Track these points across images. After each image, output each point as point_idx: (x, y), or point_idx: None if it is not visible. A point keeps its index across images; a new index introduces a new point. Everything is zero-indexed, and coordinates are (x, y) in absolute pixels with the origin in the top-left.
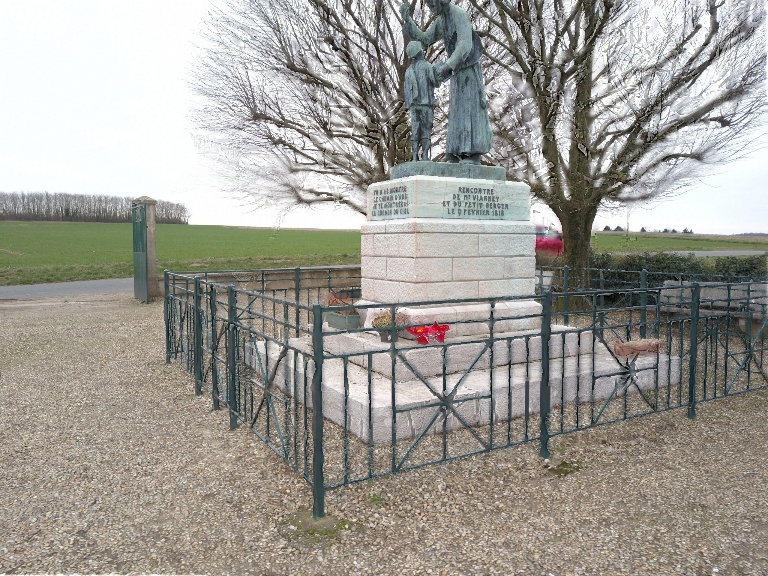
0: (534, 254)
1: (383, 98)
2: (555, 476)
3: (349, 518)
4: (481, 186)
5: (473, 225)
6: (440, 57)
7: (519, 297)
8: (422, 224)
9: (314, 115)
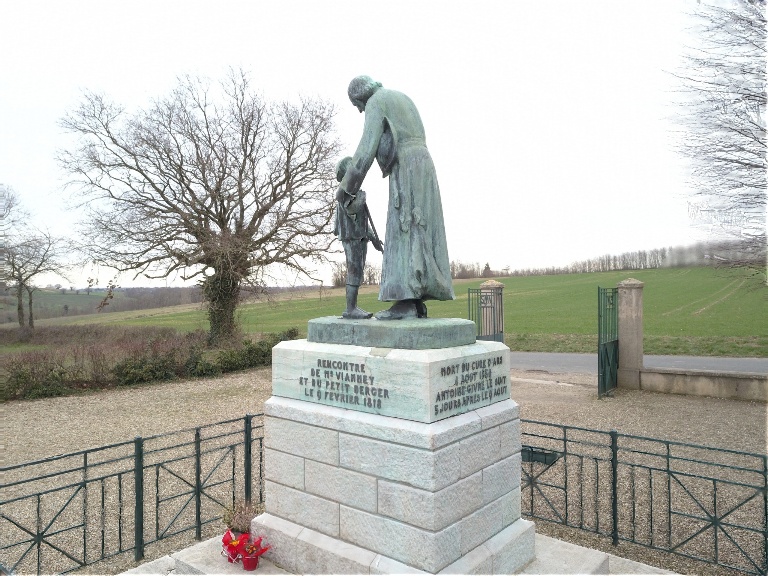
0: (430, 487)
1: None
2: None
3: None
4: (348, 359)
5: (330, 417)
6: None
7: None
8: (271, 406)
9: None
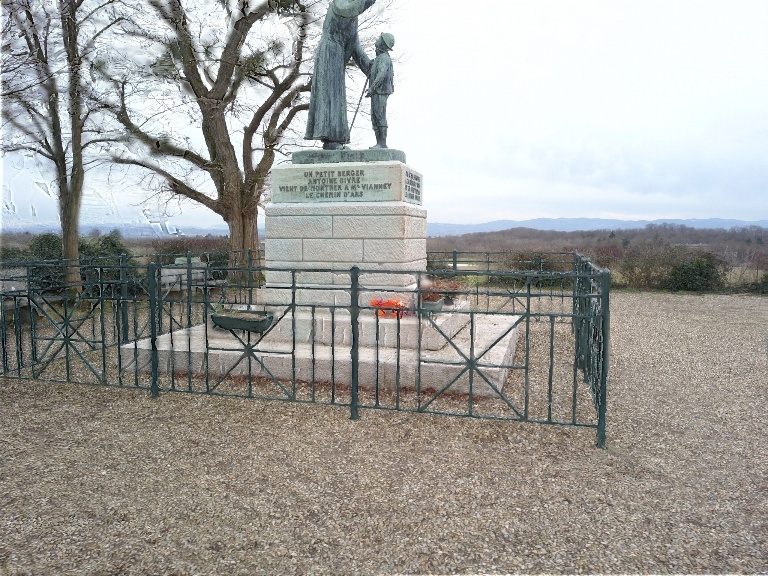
0: None
1: None
2: None
3: None
4: None
5: None
6: None
7: None
8: None
9: None
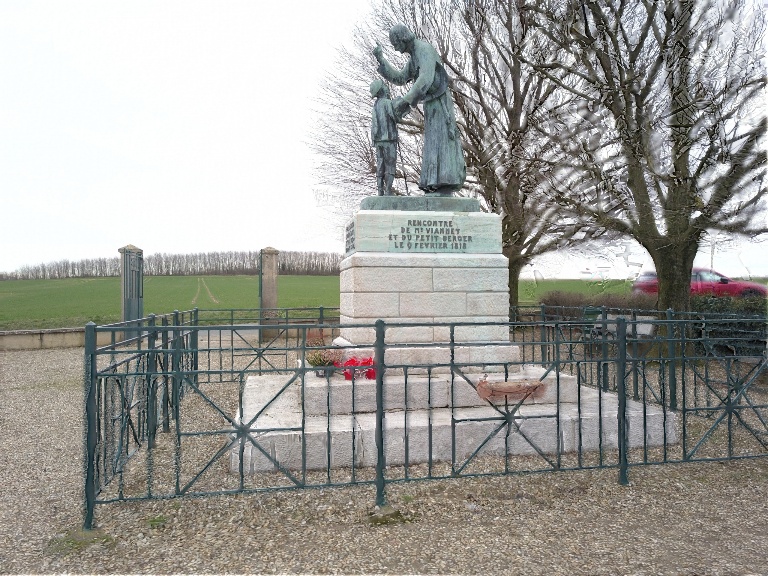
0: (507, 290)
1: (480, 141)
2: (368, 524)
3: (113, 533)
4: (436, 218)
5: (425, 259)
6: (557, 95)
7: (339, 326)
8: (361, 258)
9: (412, 163)
